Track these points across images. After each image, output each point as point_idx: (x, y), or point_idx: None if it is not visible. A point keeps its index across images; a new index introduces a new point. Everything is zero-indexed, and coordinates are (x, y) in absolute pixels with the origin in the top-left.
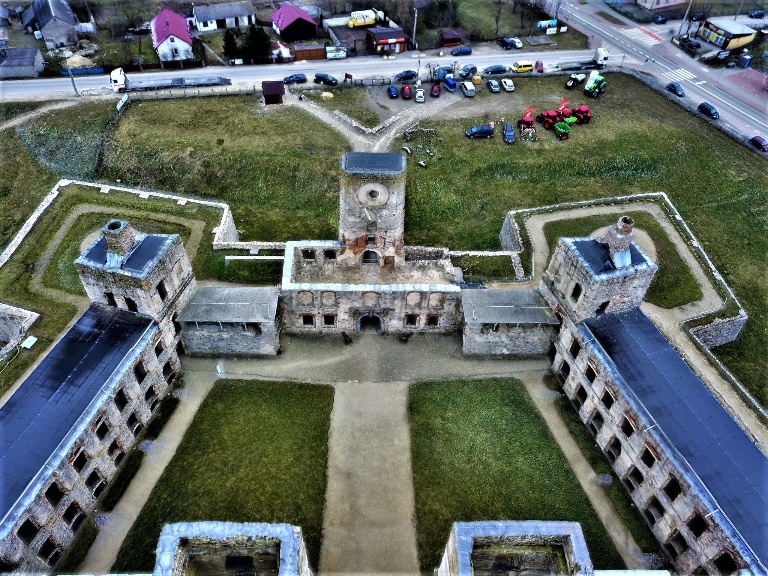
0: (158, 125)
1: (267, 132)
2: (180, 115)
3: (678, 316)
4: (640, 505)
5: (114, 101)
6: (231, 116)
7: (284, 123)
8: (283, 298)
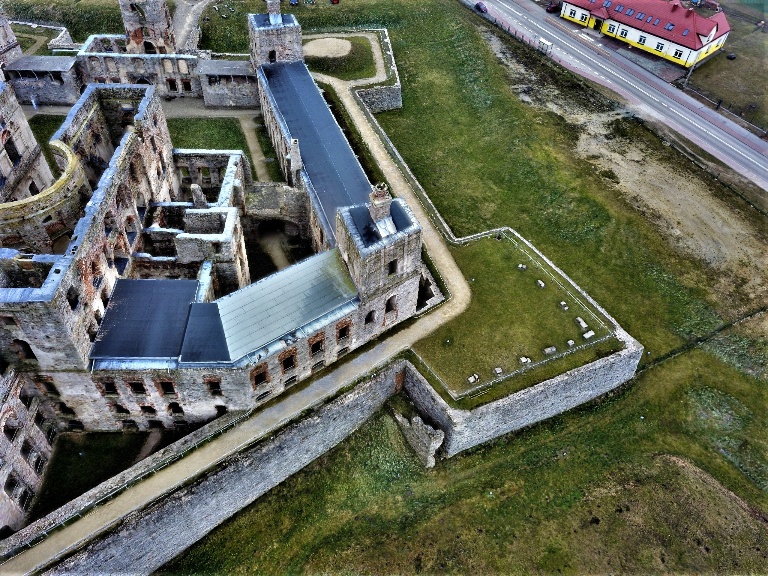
0: None
1: None
2: None
3: (351, 84)
4: (282, 167)
5: None
6: None
7: None
8: (80, 63)
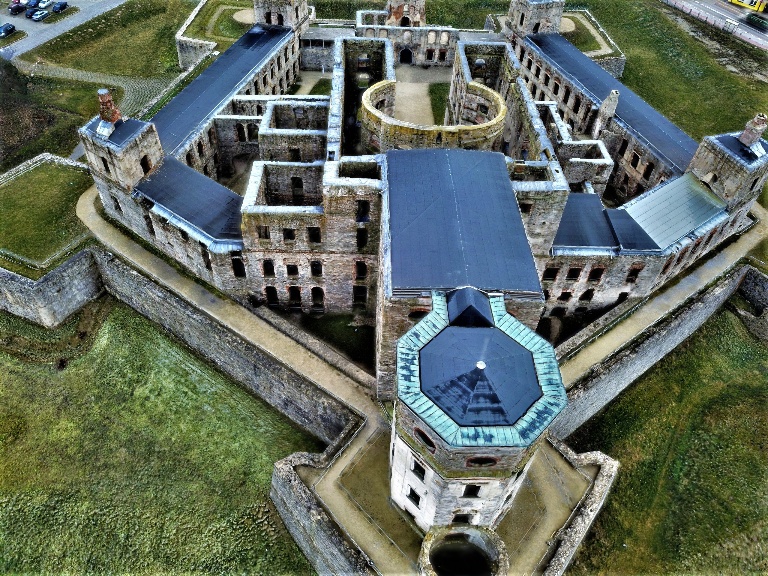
0: None
1: None
2: None
3: None
4: None
5: None
6: None
7: None
8: (358, 34)
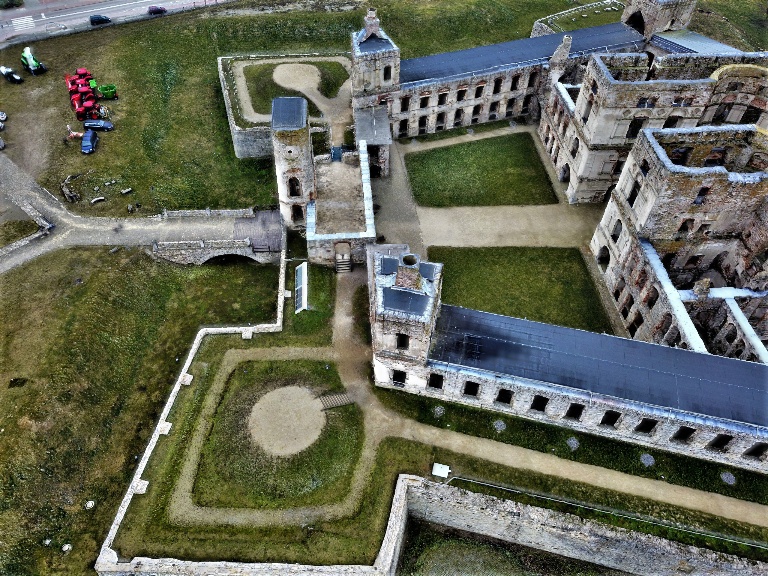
0: None
1: (8, 331)
2: None
3: None
4: (487, 119)
5: None
6: None
7: None
8: None
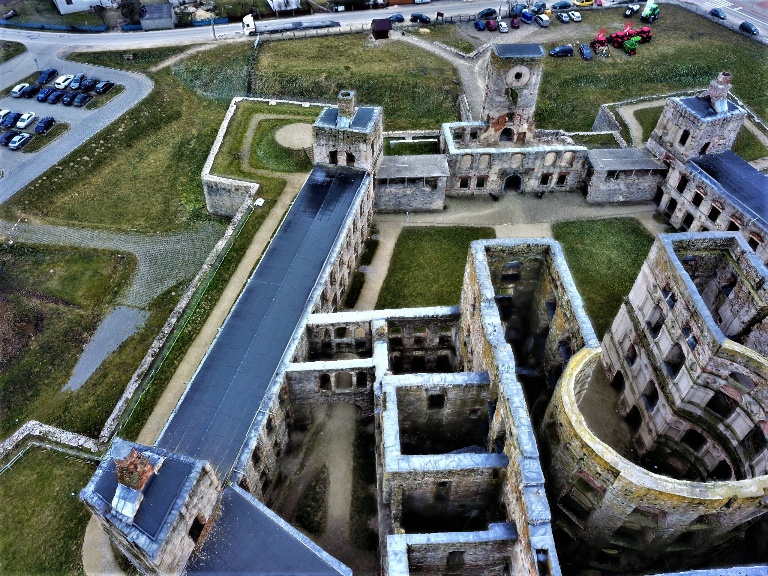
0: (291, 58)
1: (383, 60)
2: (307, 50)
3: None
4: None
5: (247, 42)
6: (349, 49)
7: (395, 53)
8: (450, 162)
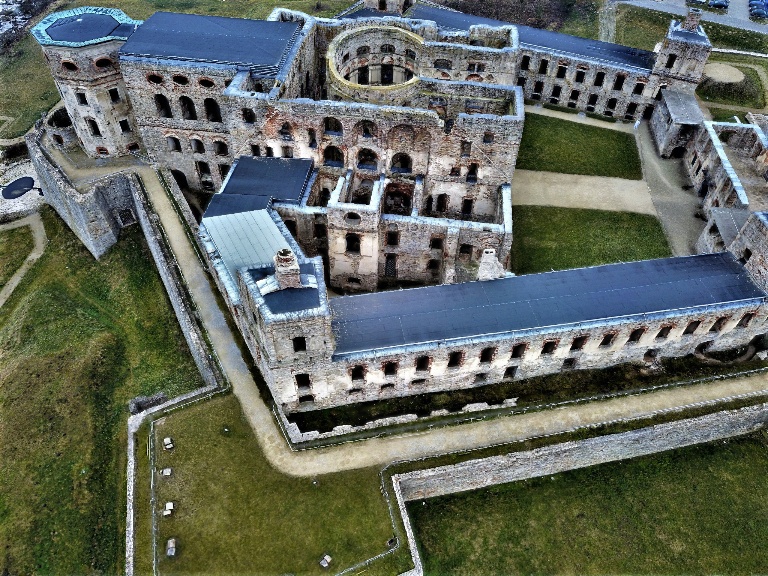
0: None
1: None
2: None
3: None
4: None
5: None
6: None
7: None
8: None
